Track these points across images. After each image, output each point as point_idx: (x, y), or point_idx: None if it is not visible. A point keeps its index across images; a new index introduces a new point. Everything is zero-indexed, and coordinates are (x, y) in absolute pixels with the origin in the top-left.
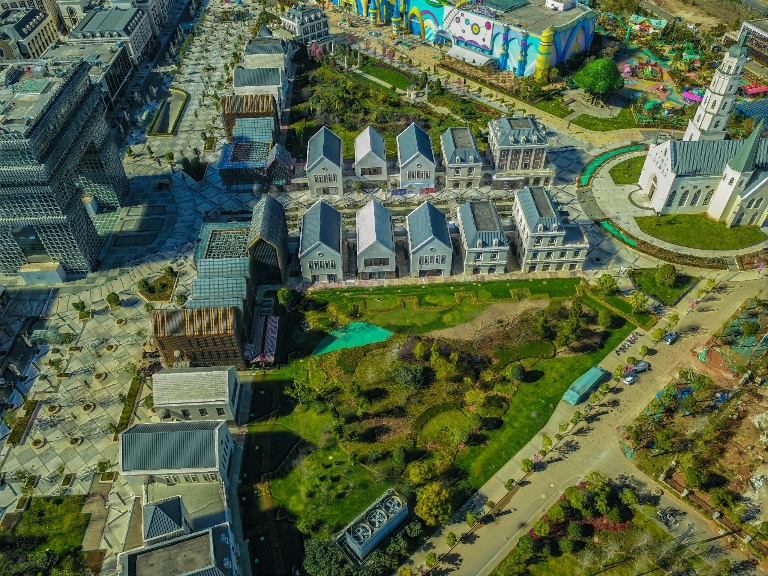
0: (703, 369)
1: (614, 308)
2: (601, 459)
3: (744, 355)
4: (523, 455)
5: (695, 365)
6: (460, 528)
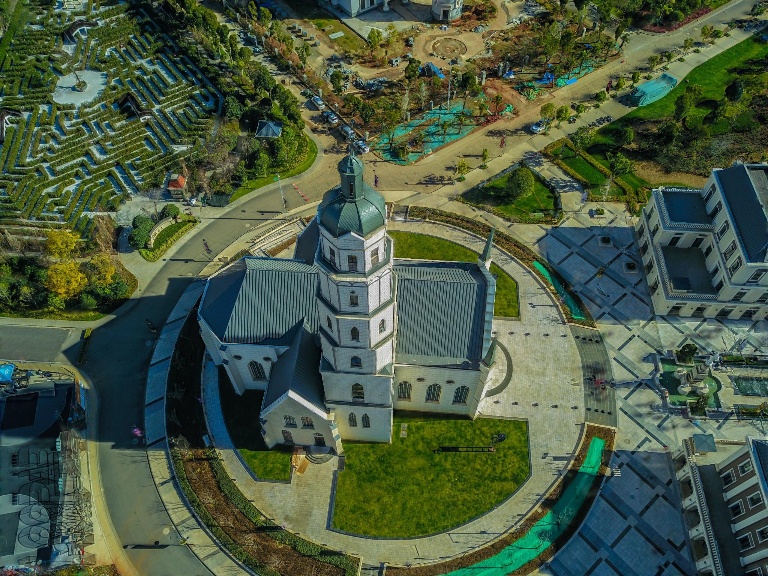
0: (515, 99)
1: (599, 165)
2: (643, 45)
3: (462, 106)
4: (715, 51)
5: (522, 102)
6: (765, 17)
